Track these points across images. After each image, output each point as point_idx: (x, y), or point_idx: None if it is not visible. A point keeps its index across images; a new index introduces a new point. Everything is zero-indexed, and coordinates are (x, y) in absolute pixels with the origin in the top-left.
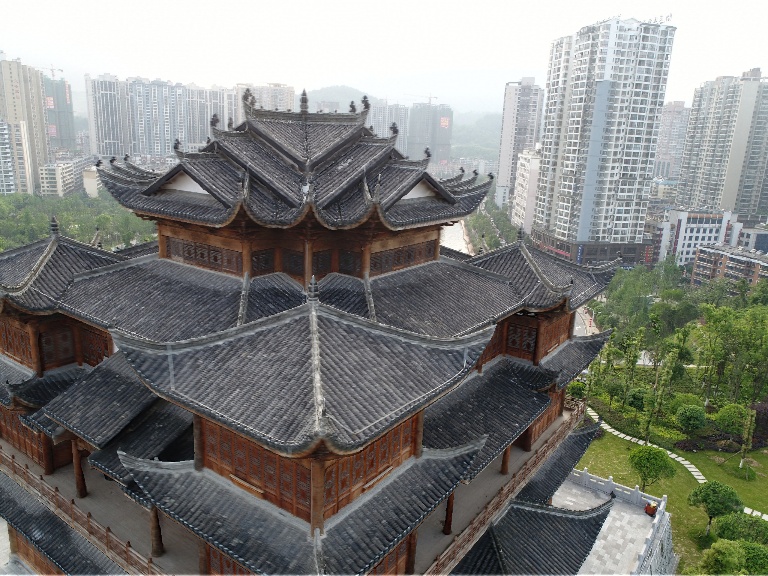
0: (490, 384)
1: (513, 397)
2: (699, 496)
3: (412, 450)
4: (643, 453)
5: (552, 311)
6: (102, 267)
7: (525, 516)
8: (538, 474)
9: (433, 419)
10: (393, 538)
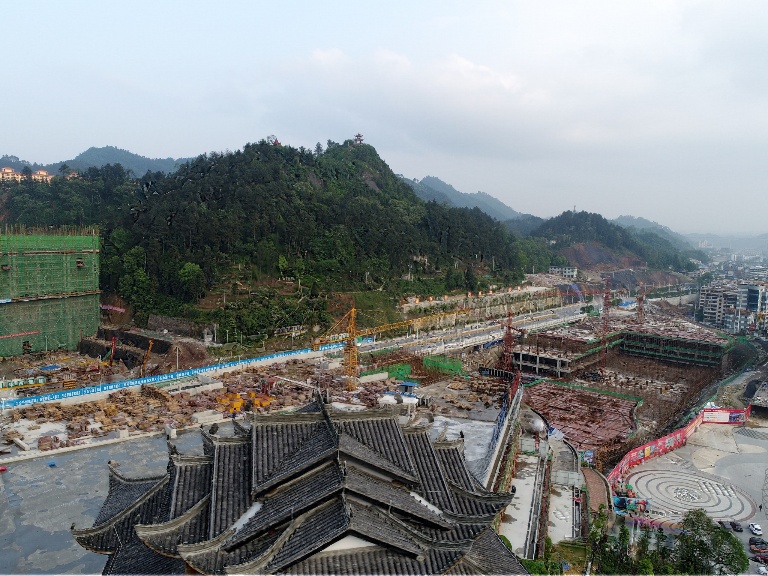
0: None
1: None
2: None
3: None
4: None
5: None
6: None
7: None
8: None
9: None
10: (104, 574)
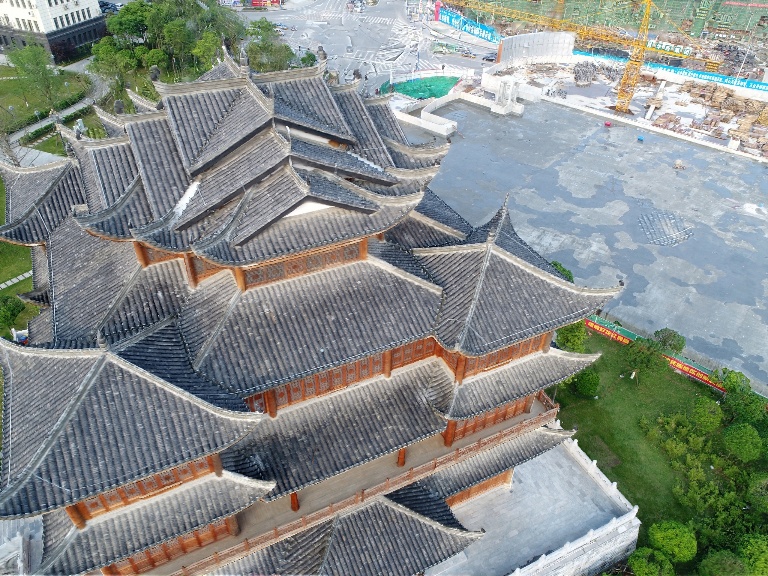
0: None
1: None
2: None
3: None
4: None
5: None
6: (444, 224)
7: None
8: None
9: None
10: None
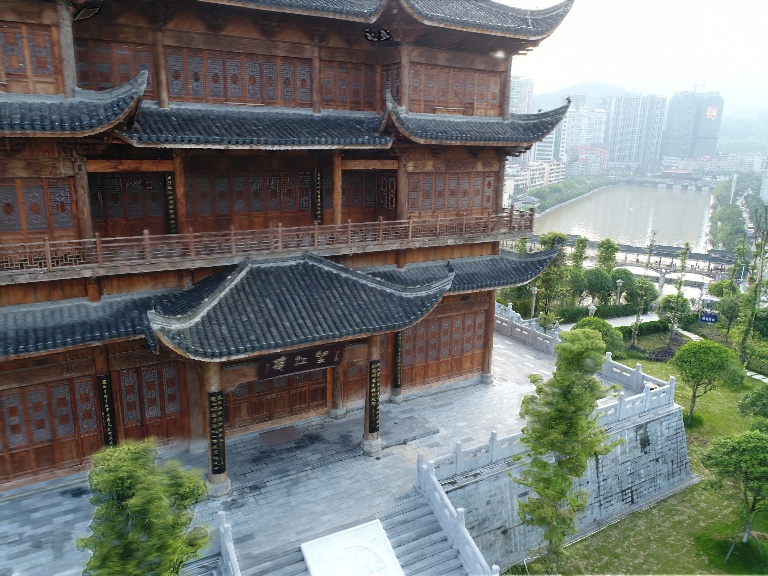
0: (317, 120)
1: (334, 130)
2: (748, 398)
3: (60, 86)
4: (690, 346)
5: (390, 14)
6: None
7: (317, 274)
8: (417, 274)
9: (180, 114)
10: None
